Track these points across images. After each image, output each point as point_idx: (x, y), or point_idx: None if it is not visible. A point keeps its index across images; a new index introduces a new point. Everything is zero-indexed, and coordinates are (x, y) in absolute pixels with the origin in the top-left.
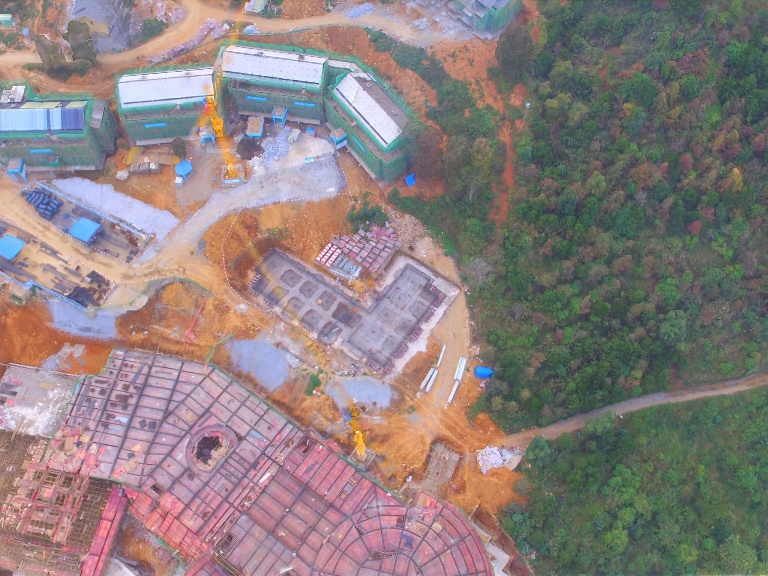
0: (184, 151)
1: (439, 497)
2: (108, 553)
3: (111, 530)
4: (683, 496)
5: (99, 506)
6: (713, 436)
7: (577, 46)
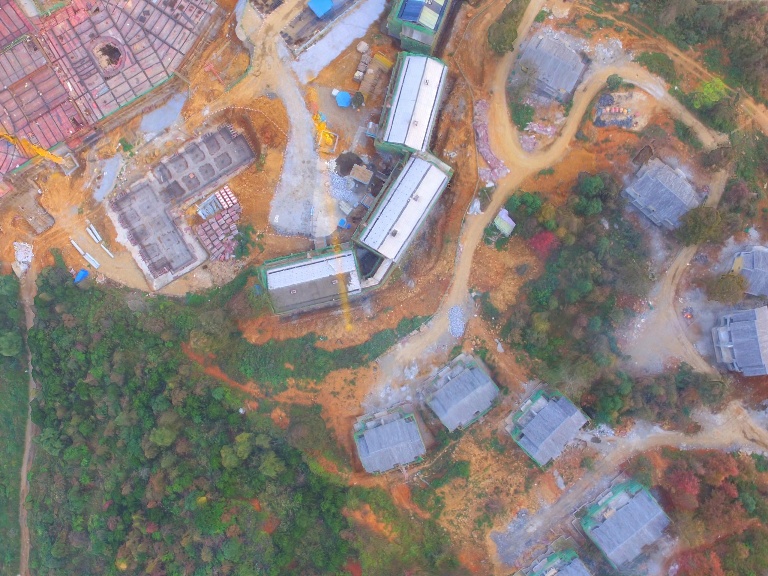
0: None
1: (5, 201)
2: None
3: None
4: None
5: None
6: (3, 441)
7: None
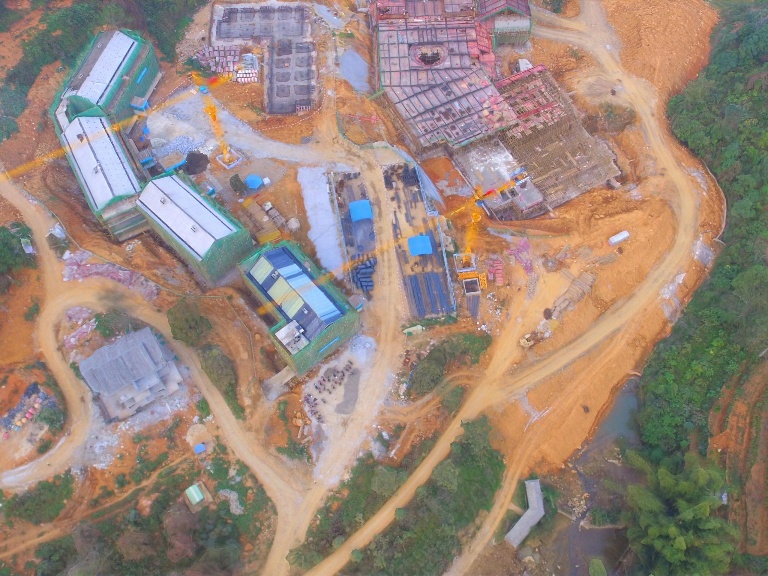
0: None
1: None
2: None
3: None
4: None
5: None
6: None
7: None
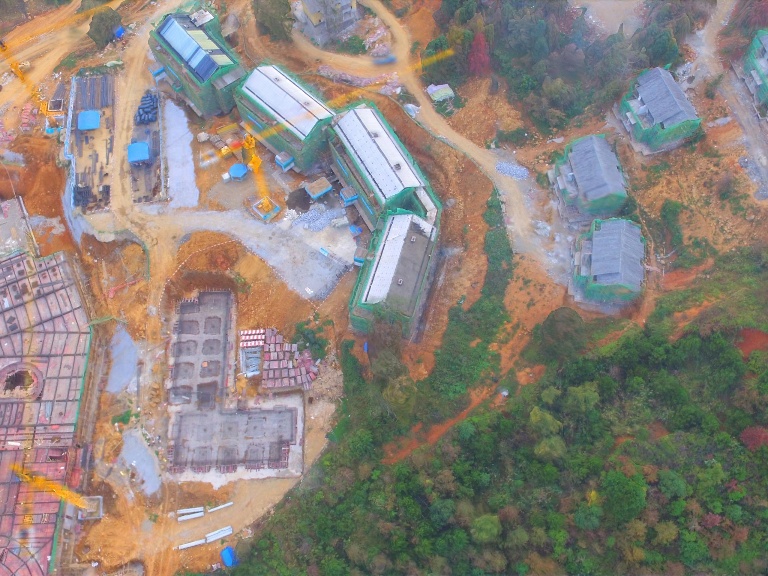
0: (249, 158)
1: None
2: None
3: None
4: None
5: None
6: None
7: (633, 389)
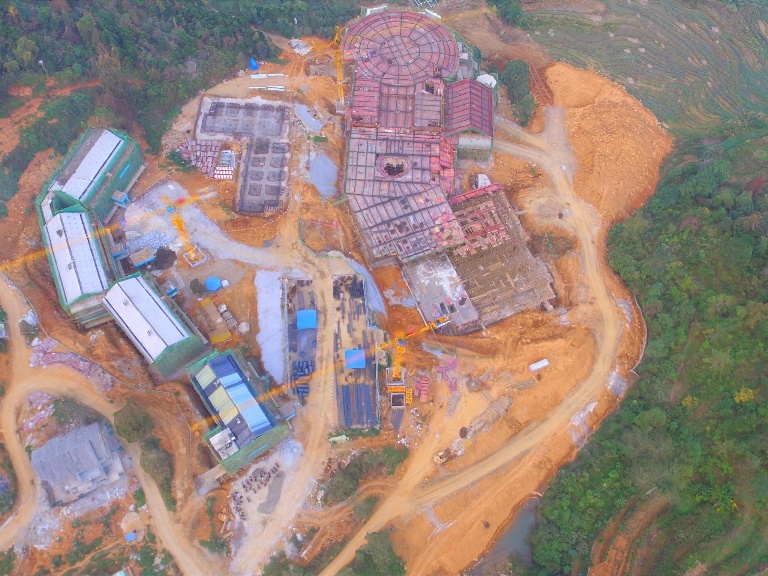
0: None
1: None
2: None
3: (469, 193)
4: None
5: None
6: None
7: None
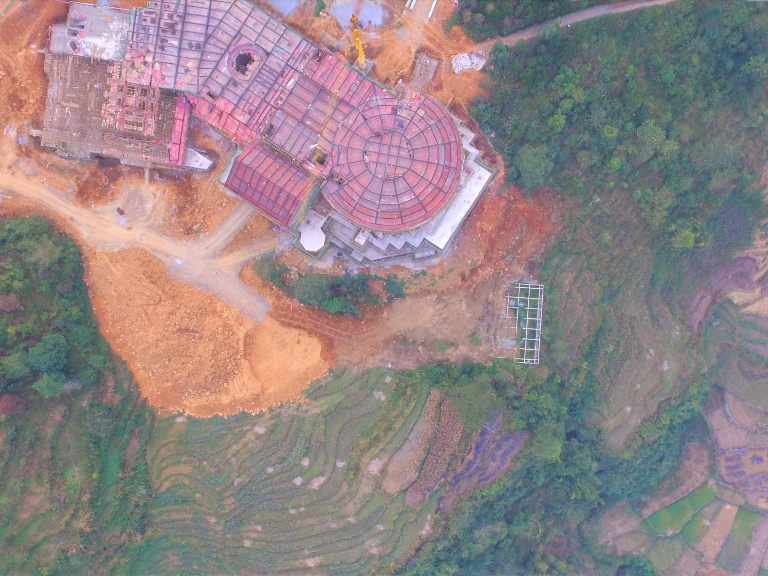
0: None
1: (422, 91)
2: (185, 143)
3: (184, 127)
4: (613, 90)
5: (171, 110)
6: (644, 41)
7: None
